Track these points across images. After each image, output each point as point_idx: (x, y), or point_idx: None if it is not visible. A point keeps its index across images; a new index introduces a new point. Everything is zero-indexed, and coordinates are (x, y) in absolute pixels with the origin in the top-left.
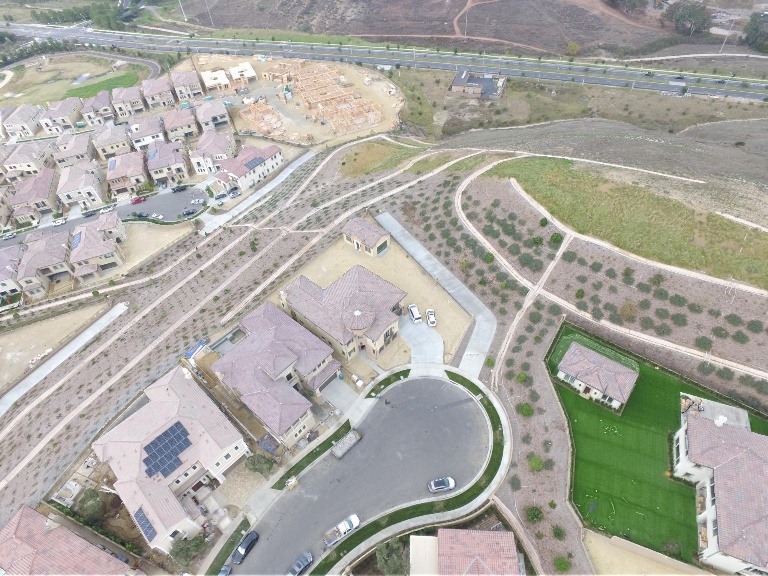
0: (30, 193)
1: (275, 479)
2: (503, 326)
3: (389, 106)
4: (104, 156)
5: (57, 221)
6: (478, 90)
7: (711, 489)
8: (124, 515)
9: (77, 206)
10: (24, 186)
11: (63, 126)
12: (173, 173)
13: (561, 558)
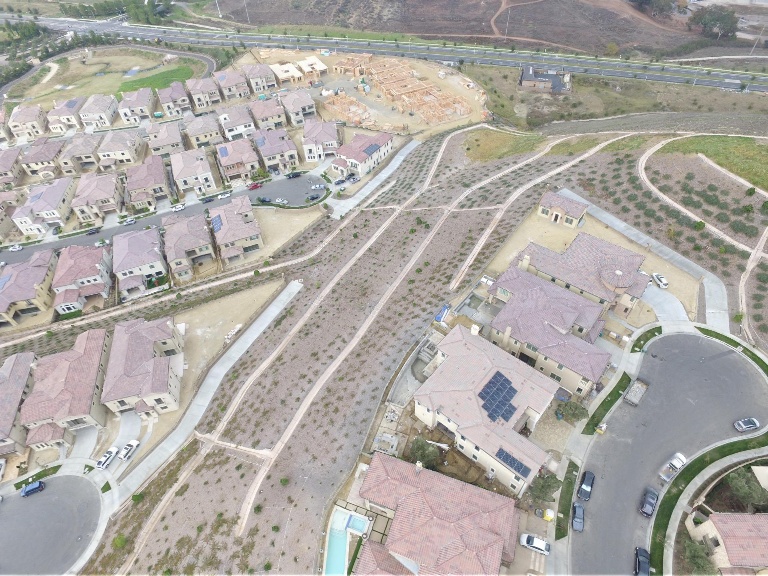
0: (147, 179)
1: (582, 426)
2: (732, 287)
3: (472, 98)
4: (197, 145)
5: (177, 206)
6: (549, 85)
7: None
8: (451, 462)
9: (191, 192)
10: (136, 172)
11: (140, 116)
12: (286, 160)
13: None
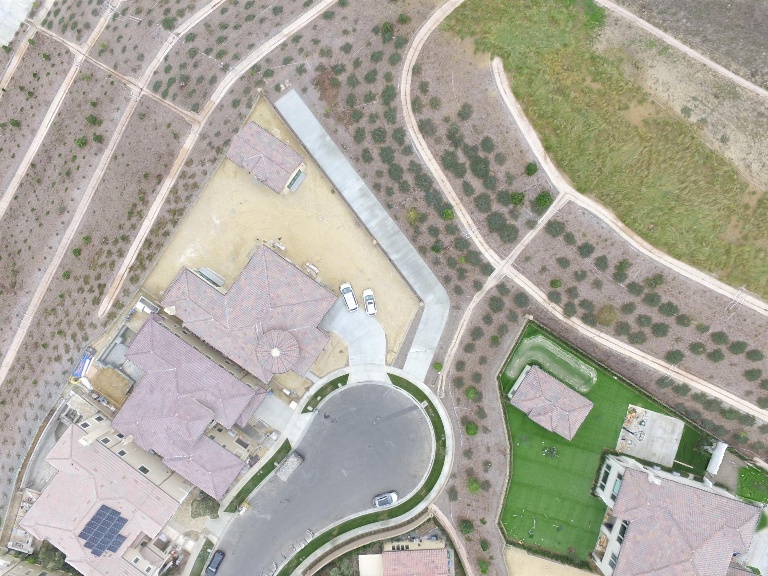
0: None
1: (225, 504)
2: (457, 311)
3: None
4: None
5: None
6: None
7: (621, 527)
8: None
9: None
10: None
11: None
12: None
13: (484, 558)
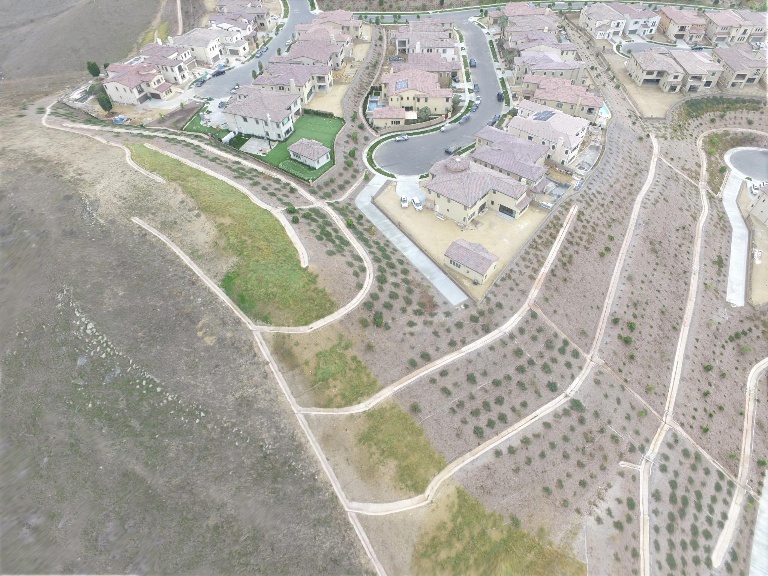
0: None
1: None
2: (351, 198)
3: None
4: None
5: None
6: None
7: None
8: None
9: None
10: None
11: None
12: None
13: (355, 118)
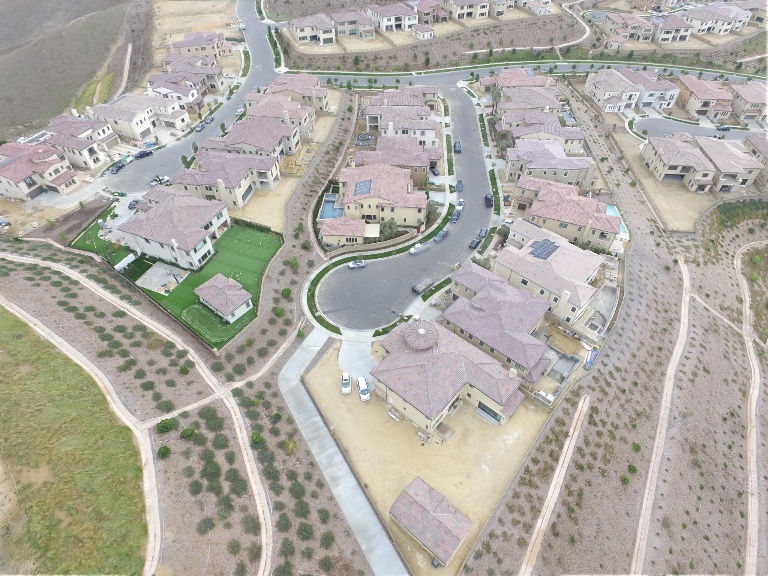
0: None
1: None
2: (274, 371)
3: None
4: None
5: None
6: None
7: None
8: None
9: None
10: None
11: None
12: None
13: (299, 231)
